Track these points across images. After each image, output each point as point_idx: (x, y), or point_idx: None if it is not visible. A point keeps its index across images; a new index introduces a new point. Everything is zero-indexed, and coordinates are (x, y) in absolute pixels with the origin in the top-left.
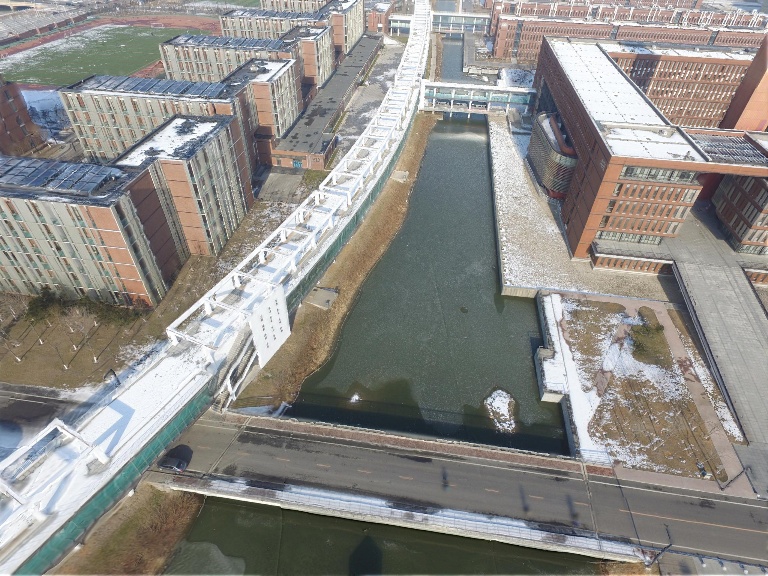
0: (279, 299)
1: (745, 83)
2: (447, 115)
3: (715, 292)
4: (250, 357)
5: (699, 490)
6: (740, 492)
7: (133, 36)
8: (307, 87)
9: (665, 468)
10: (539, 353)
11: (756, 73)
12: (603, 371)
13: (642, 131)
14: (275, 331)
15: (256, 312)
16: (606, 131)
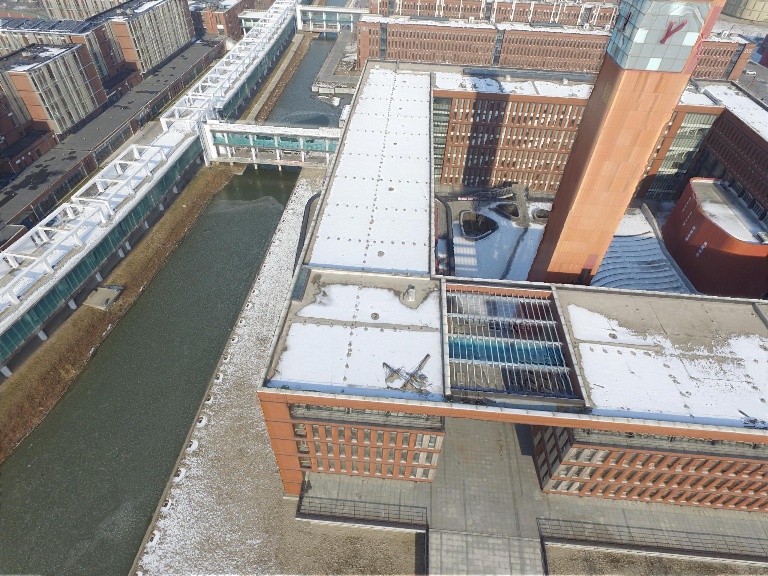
0: None
1: (561, 192)
2: (252, 166)
3: None
4: None
5: None
6: None
7: None
8: (34, 137)
9: None
10: None
11: (571, 182)
12: None
13: (376, 291)
14: None
15: None
16: (309, 295)
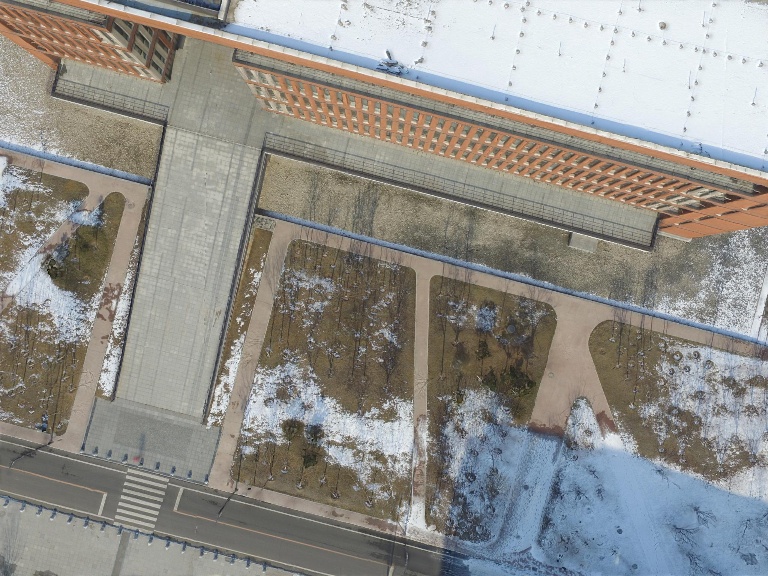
0: None
1: None
2: None
3: (194, 193)
4: None
5: (29, 441)
6: (67, 447)
7: None
8: None
9: (9, 416)
10: None
11: None
12: (4, 295)
13: None
14: None
15: None
16: None
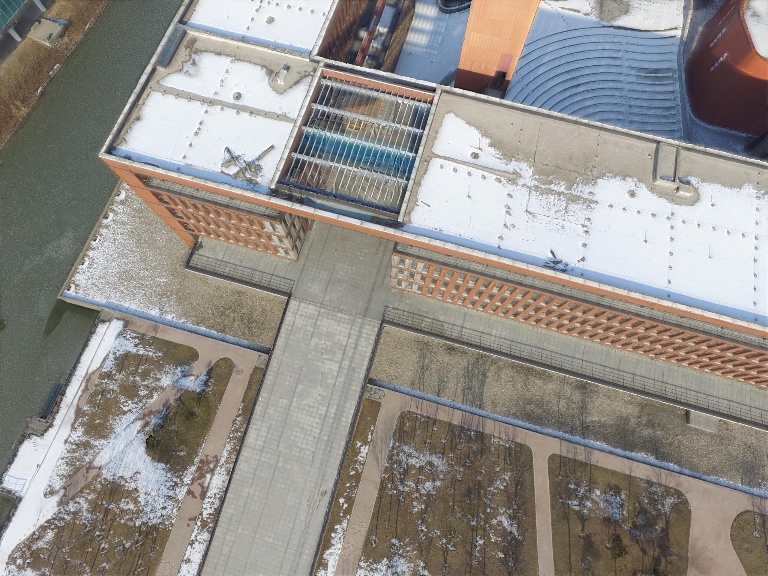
0: None
1: None
2: None
3: (311, 362)
4: None
5: None
6: None
7: None
8: None
9: None
10: (28, 426)
11: None
12: (90, 466)
13: (247, 66)
14: None
15: None
16: (177, 62)
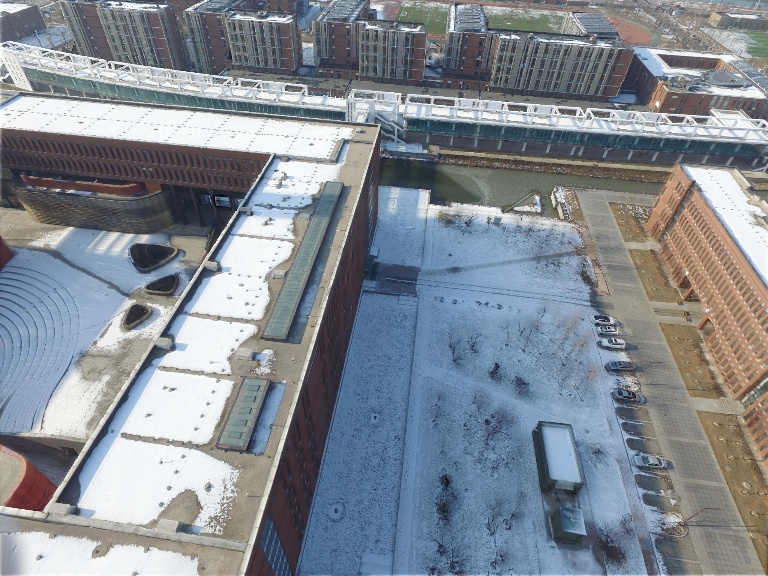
0: (16, 62)
1: None
2: None
3: None
4: (7, 73)
5: None
6: None
7: (541, 23)
8: None
9: None
10: None
11: None
12: None
13: None
14: (20, 77)
15: (2, 53)
16: None
